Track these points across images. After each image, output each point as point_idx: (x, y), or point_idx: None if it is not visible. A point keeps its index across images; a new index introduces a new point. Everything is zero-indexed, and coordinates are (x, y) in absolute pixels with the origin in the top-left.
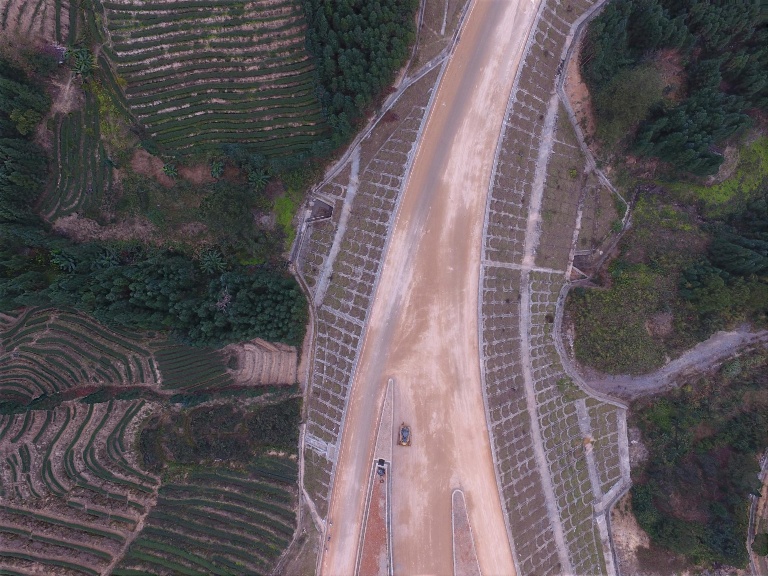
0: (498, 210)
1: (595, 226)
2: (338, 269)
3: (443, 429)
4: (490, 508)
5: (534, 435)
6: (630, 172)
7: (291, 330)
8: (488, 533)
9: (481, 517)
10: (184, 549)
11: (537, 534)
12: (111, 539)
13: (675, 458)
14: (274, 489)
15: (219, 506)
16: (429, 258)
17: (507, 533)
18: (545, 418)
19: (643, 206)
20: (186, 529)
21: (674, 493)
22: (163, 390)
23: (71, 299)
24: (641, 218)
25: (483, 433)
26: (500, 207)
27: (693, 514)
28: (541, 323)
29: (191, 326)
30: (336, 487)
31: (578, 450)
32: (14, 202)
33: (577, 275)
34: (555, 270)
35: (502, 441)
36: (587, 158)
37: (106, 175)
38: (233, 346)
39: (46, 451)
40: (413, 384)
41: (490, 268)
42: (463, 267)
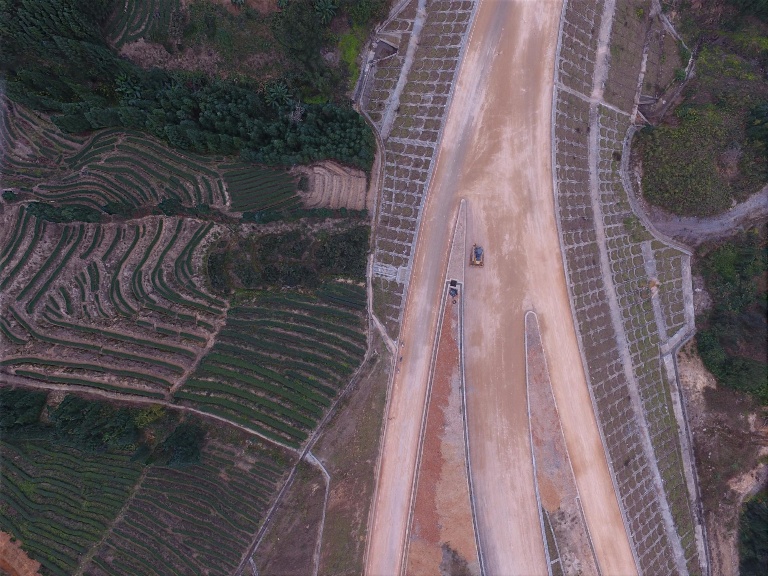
0: (570, 34)
1: (659, 72)
2: (406, 100)
3: (516, 251)
4: (563, 330)
5: (603, 268)
6: (694, 19)
7: (364, 147)
8: (561, 356)
9: (554, 339)
10: (256, 364)
11: (608, 363)
12: (182, 355)
13: (739, 308)
14: (344, 313)
15: (289, 327)
16: (502, 79)
17: (580, 355)
18: (614, 252)
19: (706, 56)
20: (257, 347)
21: (739, 340)
22: (232, 213)
23: (141, 116)
24: (704, 68)
25: (556, 255)
26: (572, 31)
27: (759, 359)
28: (609, 159)
29: (261, 147)
30: (408, 308)
31: (644, 292)
32: (85, 14)
33: (641, 120)
34: (621, 111)
35: (574, 265)
36: (652, 1)
37: (173, 1)
38: (303, 169)
39: (114, 271)
40: (485, 206)
41: (562, 91)
42: (536, 89)
